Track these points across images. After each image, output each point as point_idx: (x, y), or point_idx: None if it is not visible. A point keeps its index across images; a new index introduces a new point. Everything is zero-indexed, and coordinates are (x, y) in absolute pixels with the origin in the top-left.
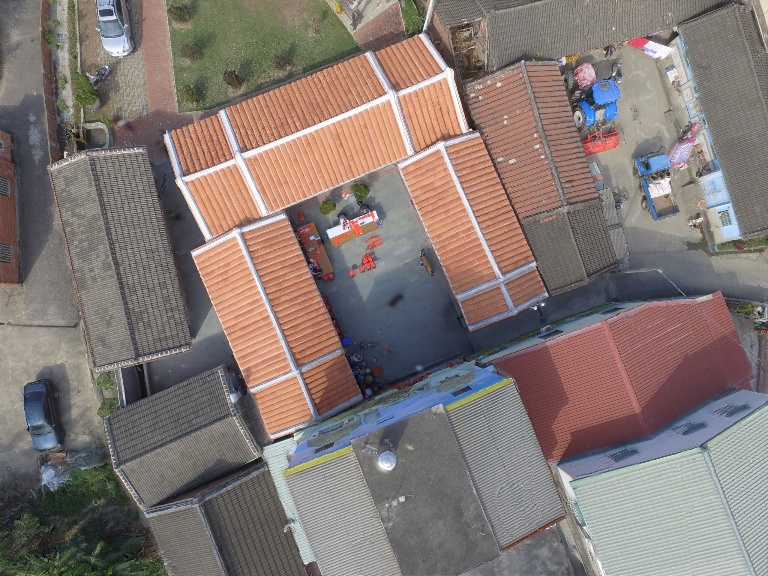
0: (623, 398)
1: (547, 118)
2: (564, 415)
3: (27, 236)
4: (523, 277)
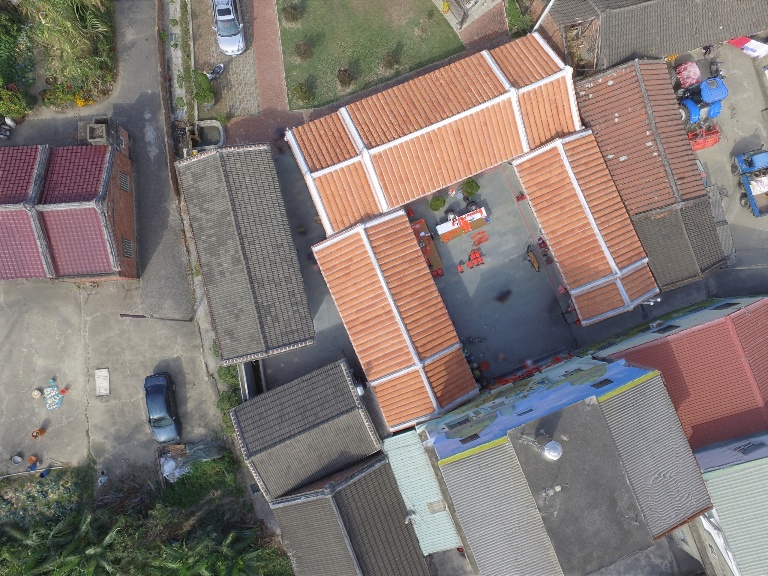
0: (746, 392)
1: (658, 116)
2: (686, 409)
3: (143, 232)
4: (636, 273)
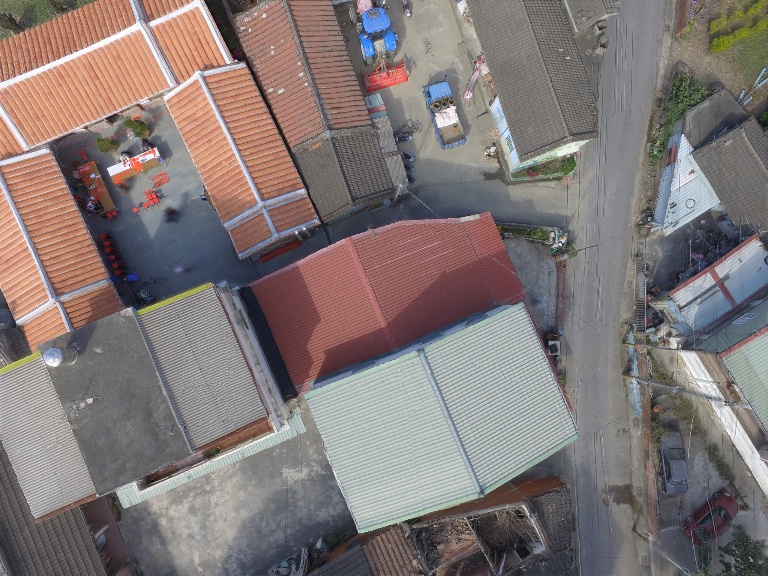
0: (369, 313)
1: (312, 46)
2: (316, 334)
3: None
4: (291, 204)
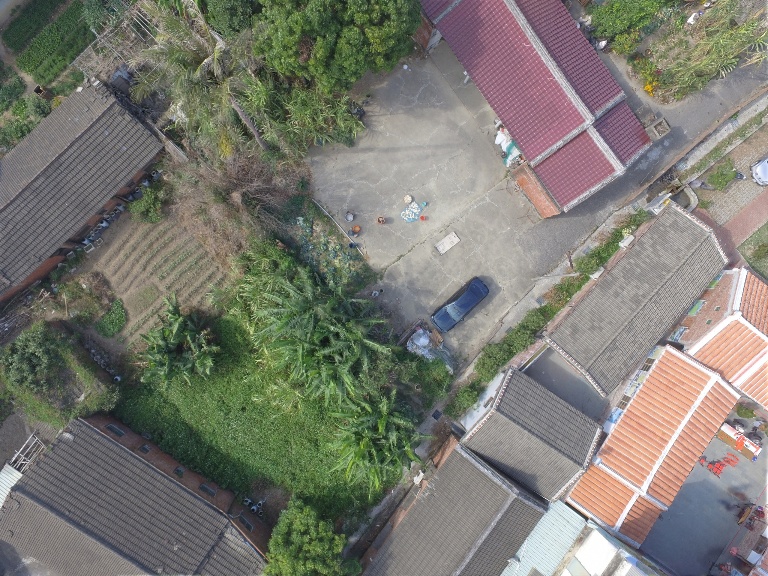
0: None
1: None
2: None
3: None
4: None
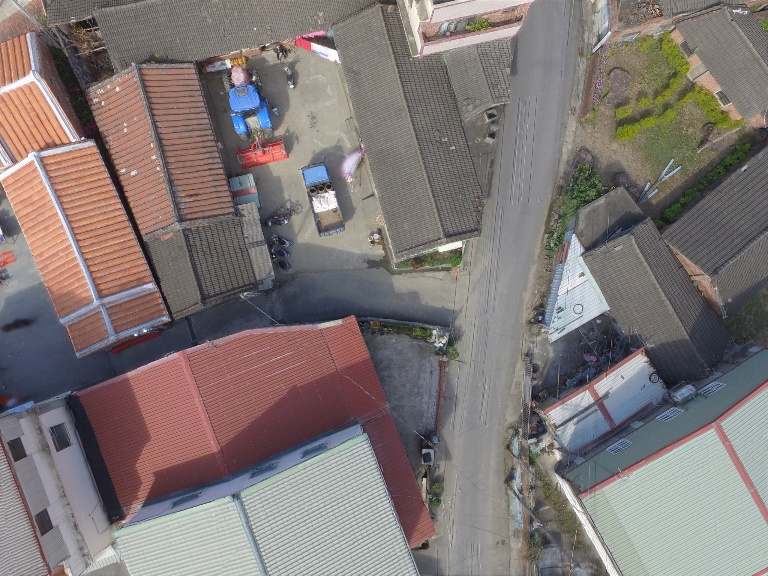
0: (201, 436)
1: (169, 126)
2: (145, 453)
3: None
4: (136, 299)
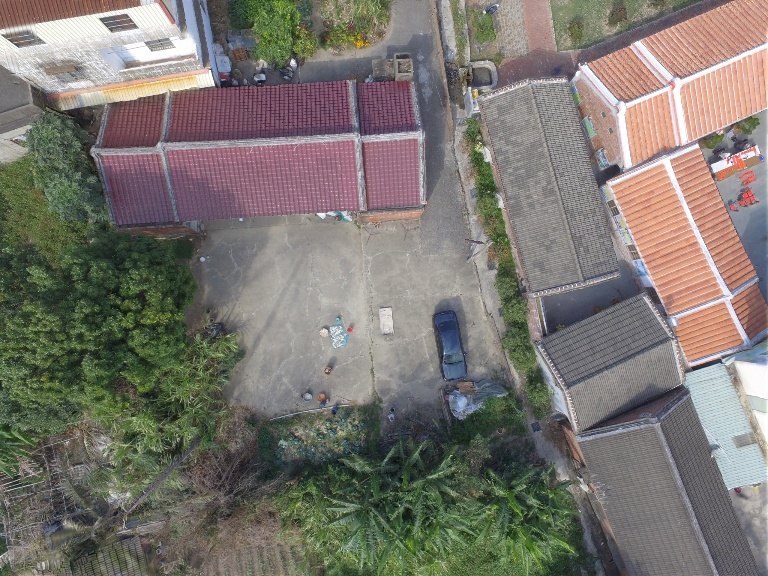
0: None
1: None
2: None
3: None
4: None
